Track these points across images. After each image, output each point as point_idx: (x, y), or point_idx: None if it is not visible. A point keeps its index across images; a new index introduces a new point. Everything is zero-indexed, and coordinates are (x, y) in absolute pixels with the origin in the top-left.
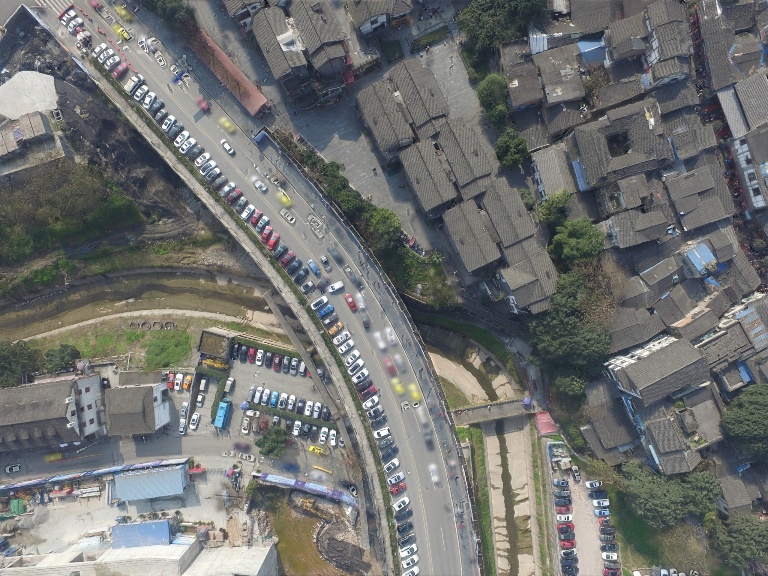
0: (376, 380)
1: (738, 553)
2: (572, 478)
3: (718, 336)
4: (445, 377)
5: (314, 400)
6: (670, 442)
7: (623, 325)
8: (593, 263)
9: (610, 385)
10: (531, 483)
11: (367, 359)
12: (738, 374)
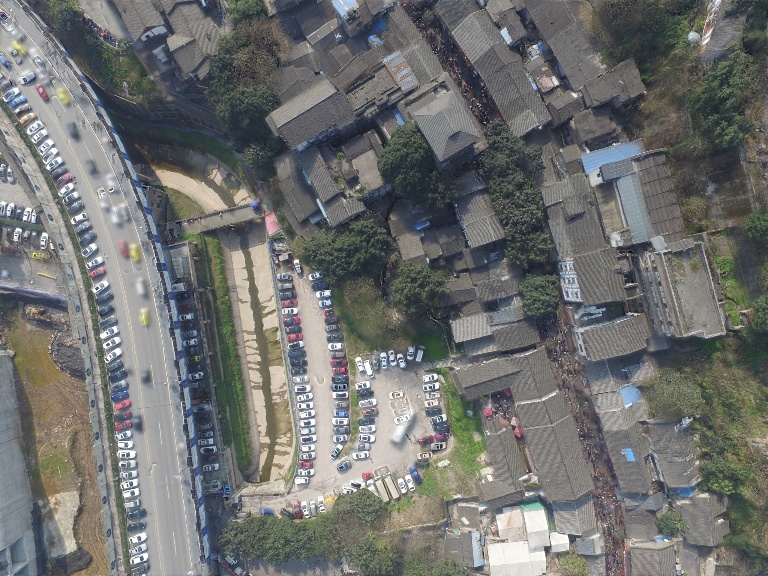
0: (71, 168)
1: (401, 295)
2: (296, 273)
3: (365, 80)
4: (182, 191)
5: (33, 207)
6: (328, 189)
7: (287, 85)
8: (252, 24)
9: (295, 156)
10: (274, 292)
11: (61, 148)
12: (396, 122)
